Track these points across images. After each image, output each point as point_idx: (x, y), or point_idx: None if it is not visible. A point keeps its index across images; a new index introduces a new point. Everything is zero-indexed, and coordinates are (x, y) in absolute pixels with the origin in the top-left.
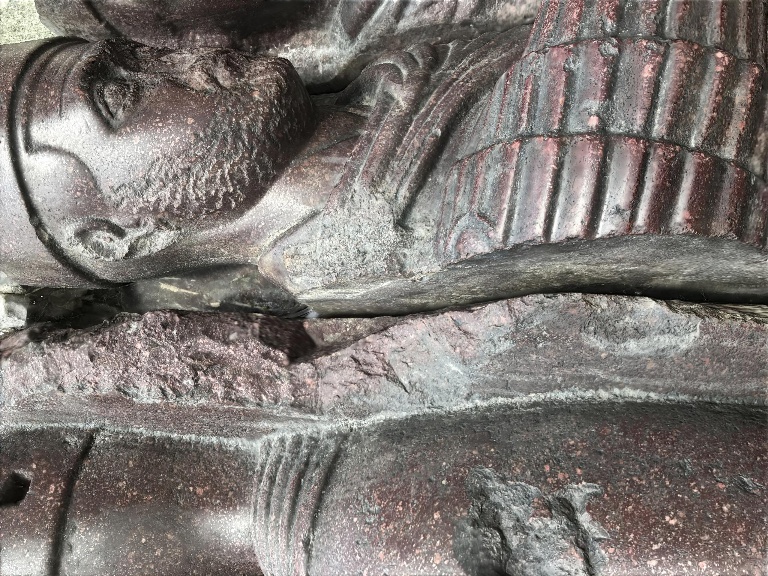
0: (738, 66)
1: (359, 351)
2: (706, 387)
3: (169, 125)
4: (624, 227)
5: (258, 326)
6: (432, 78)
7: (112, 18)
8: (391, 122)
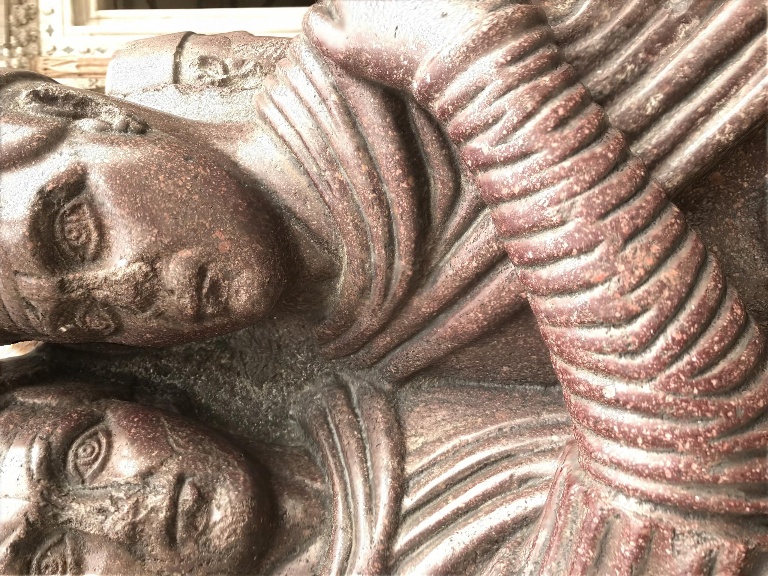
0: None
1: None
2: None
3: None
4: None
5: None
6: None
7: None
8: None
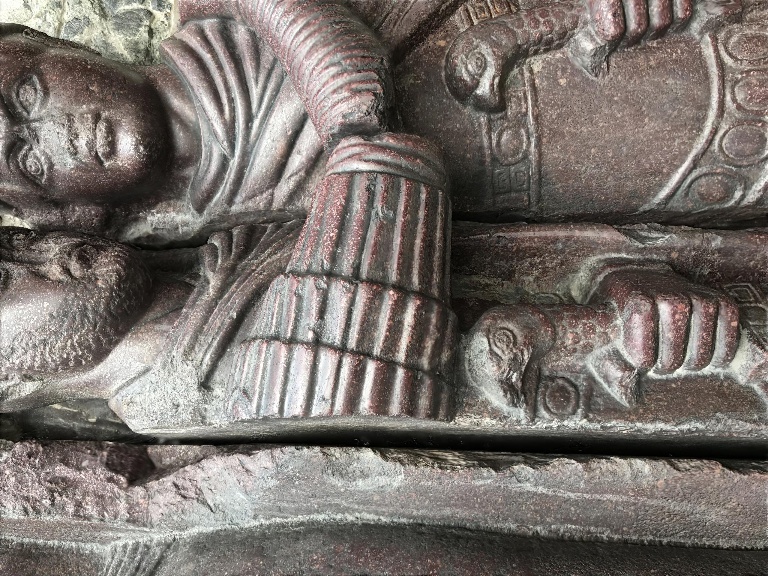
0: (406, 299)
1: (179, 478)
2: (417, 513)
3: (29, 307)
4: (327, 411)
5: (106, 454)
6: (238, 267)
7: (3, 198)
8: (201, 305)
